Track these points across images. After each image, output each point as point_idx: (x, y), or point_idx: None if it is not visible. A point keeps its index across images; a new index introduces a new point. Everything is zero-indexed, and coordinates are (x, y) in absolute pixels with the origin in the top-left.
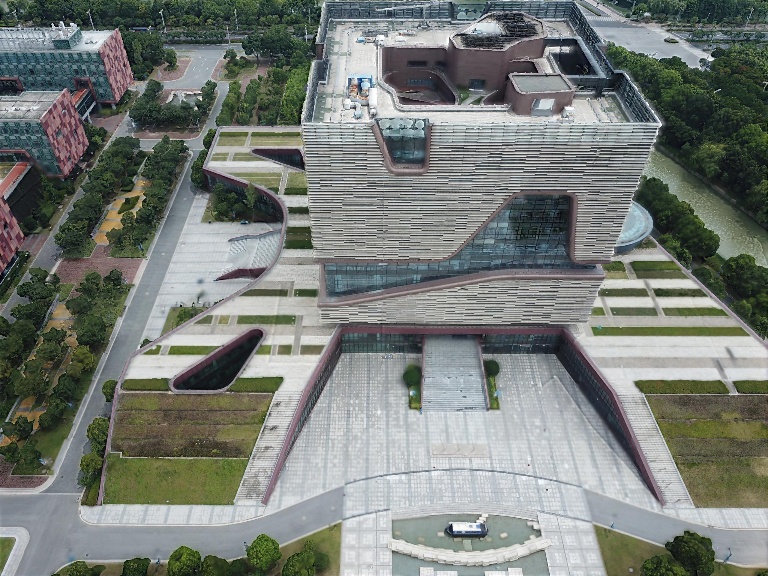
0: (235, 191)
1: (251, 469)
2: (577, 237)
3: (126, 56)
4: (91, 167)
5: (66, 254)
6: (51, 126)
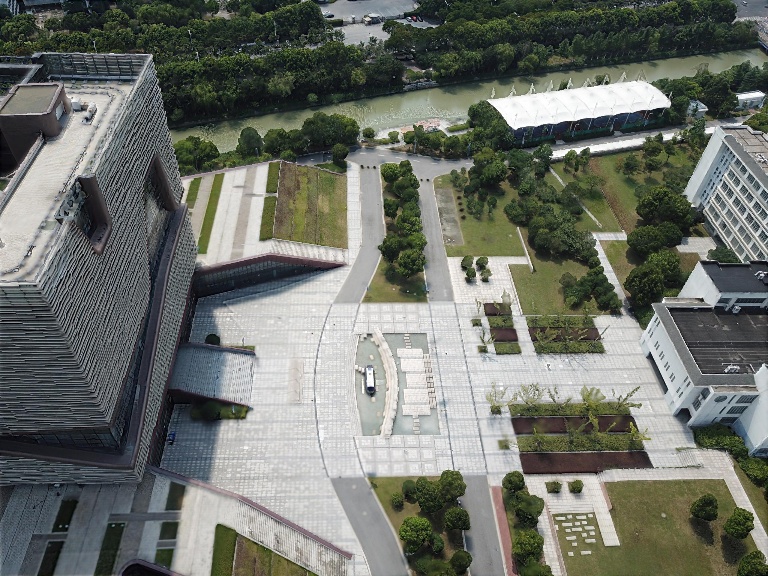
0: None
1: (318, 570)
2: (171, 187)
3: None
4: None
5: None
6: None
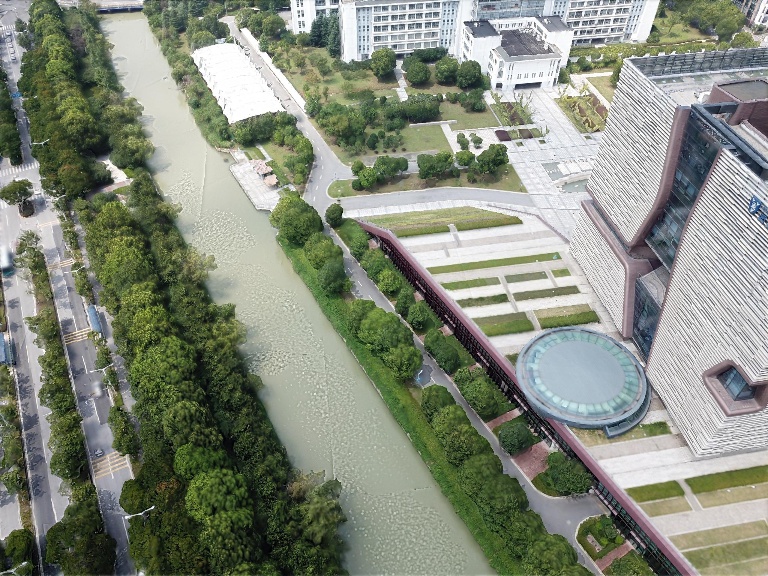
0: None
1: None
2: None
3: None
4: None
5: None
6: None
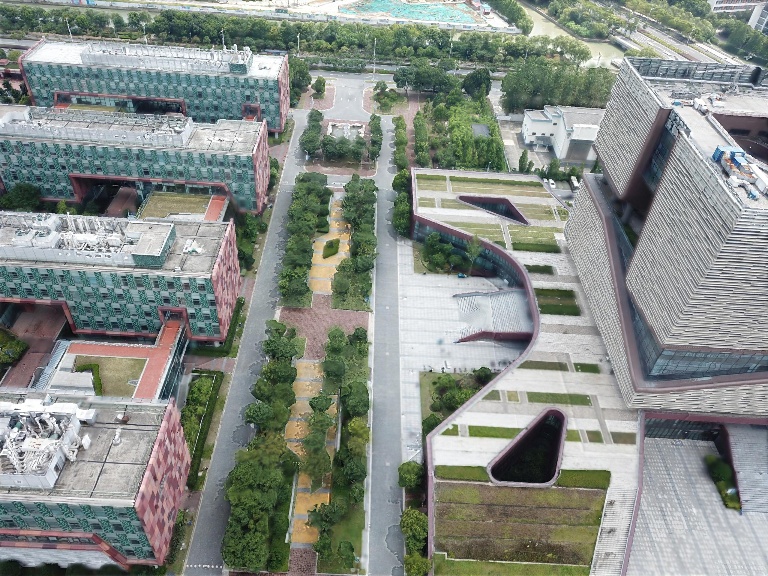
0: (448, 241)
1: None
2: None
3: (288, 83)
4: (274, 202)
5: (285, 303)
6: (258, 160)
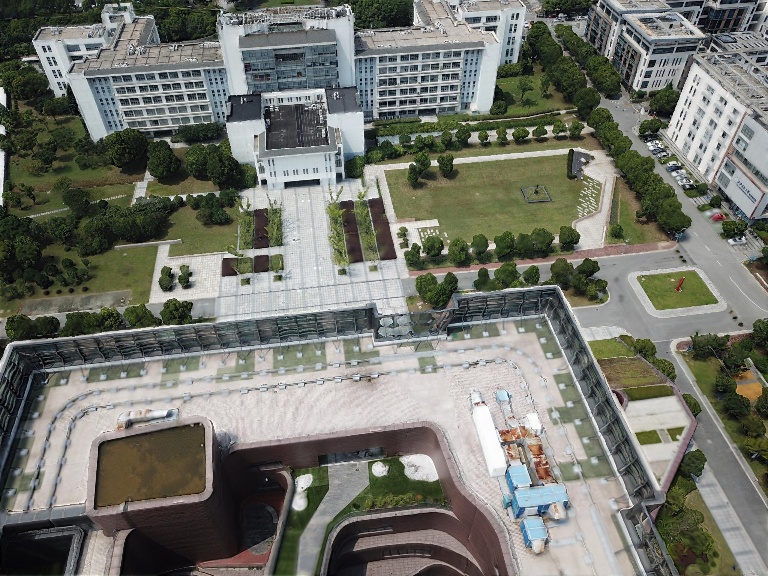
0: None
1: None
2: None
3: None
4: None
5: None
6: None
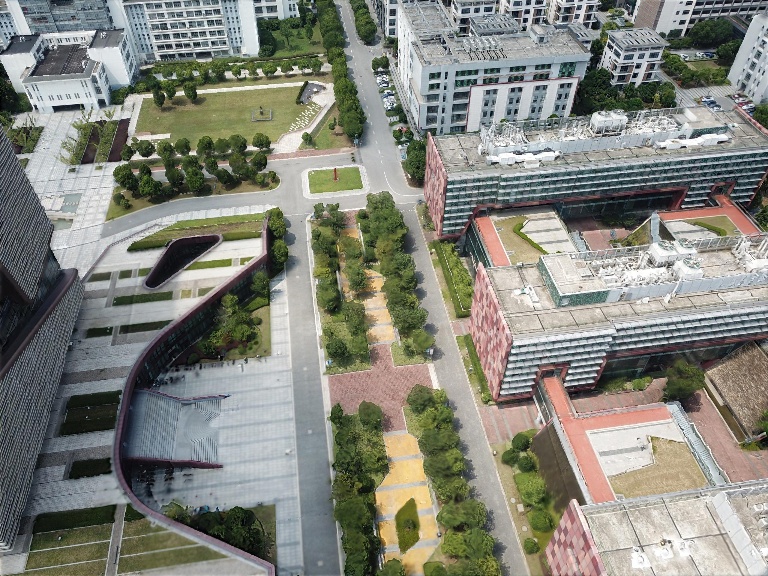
0: None
1: None
2: None
3: None
4: None
5: None
6: None
